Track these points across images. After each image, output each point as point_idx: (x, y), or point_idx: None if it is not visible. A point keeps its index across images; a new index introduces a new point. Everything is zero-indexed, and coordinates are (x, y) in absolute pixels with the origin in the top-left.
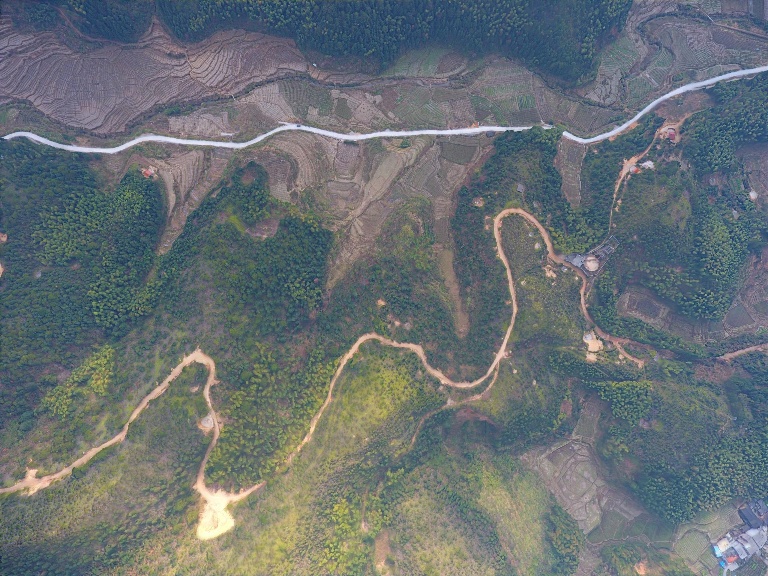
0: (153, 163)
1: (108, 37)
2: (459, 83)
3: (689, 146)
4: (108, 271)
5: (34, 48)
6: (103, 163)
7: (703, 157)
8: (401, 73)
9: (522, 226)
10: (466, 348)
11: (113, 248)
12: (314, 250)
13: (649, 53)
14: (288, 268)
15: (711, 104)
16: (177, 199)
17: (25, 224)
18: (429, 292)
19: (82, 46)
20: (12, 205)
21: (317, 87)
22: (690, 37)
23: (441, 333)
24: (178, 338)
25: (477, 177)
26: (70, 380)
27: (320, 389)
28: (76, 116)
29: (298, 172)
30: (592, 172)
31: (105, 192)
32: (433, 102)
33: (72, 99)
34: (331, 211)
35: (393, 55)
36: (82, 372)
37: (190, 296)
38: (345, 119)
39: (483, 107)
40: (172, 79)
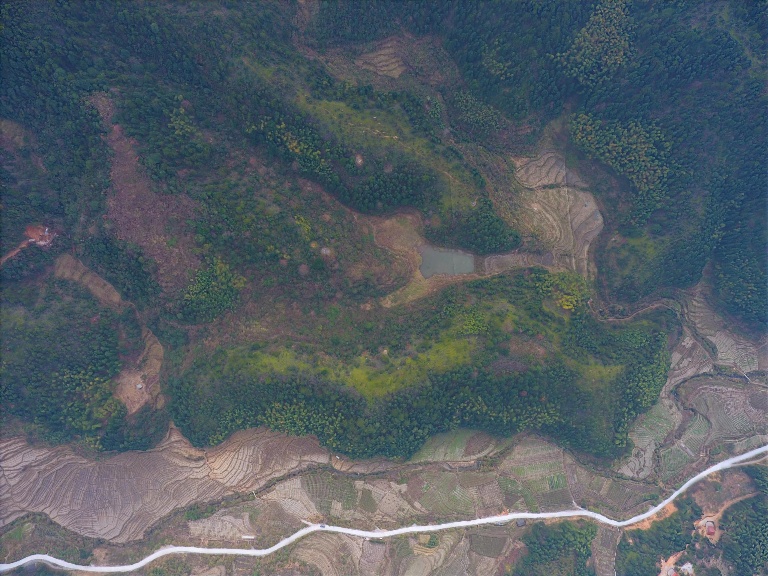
0: None
1: (125, 451)
2: (487, 465)
3: (730, 548)
4: None
5: (49, 461)
6: None
7: (744, 559)
8: (427, 458)
9: None
10: None
11: None
12: None
13: (684, 420)
14: None
15: (751, 489)
16: None
17: None
18: None
19: (98, 457)
20: None
21: (340, 479)
22: (727, 403)
23: None
24: None
25: None
26: None
27: None
28: (93, 527)
29: None
30: (628, 570)
31: None
32: (460, 488)
33: (89, 509)
34: None
35: (419, 448)
36: None
37: None
38: (370, 512)
39: (512, 490)
40: (191, 481)
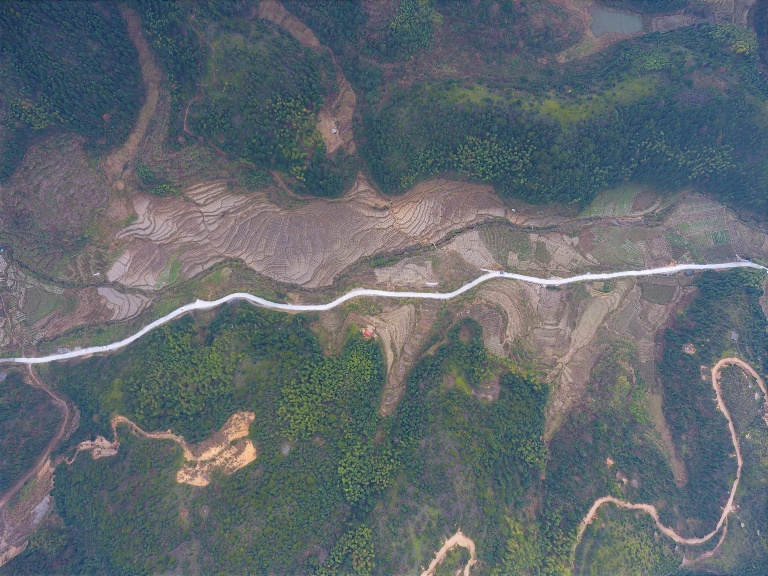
0: (369, 321)
1: (318, 196)
2: (654, 221)
3: None
4: (349, 443)
5: (245, 208)
6: (321, 322)
7: None
8: (597, 214)
9: (742, 378)
10: (689, 500)
11: (351, 419)
12: (537, 408)
13: None
14: (520, 432)
15: None
16: (395, 356)
17: (269, 400)
18: (648, 443)
19: (292, 204)
20: (257, 383)
21: (516, 232)
22: None
23: (666, 487)
24: (433, 517)
25: (683, 320)
26: (331, 562)
27: (566, 558)
28: (286, 272)
29: (508, 323)
30: None
31: (333, 358)
32: (630, 241)
33: (282, 255)
34: (539, 359)
35: (592, 199)
36: (341, 552)
37: (437, 471)
38: (545, 263)
39: (679, 244)
40: (376, 231)
